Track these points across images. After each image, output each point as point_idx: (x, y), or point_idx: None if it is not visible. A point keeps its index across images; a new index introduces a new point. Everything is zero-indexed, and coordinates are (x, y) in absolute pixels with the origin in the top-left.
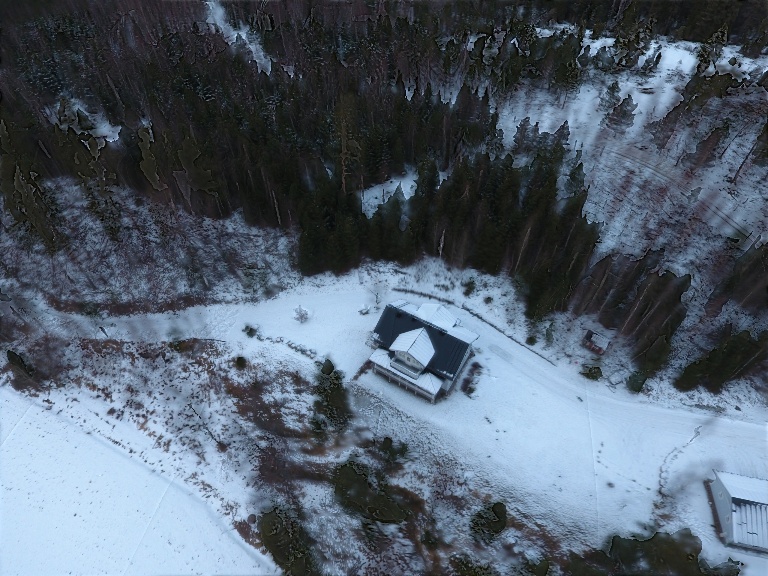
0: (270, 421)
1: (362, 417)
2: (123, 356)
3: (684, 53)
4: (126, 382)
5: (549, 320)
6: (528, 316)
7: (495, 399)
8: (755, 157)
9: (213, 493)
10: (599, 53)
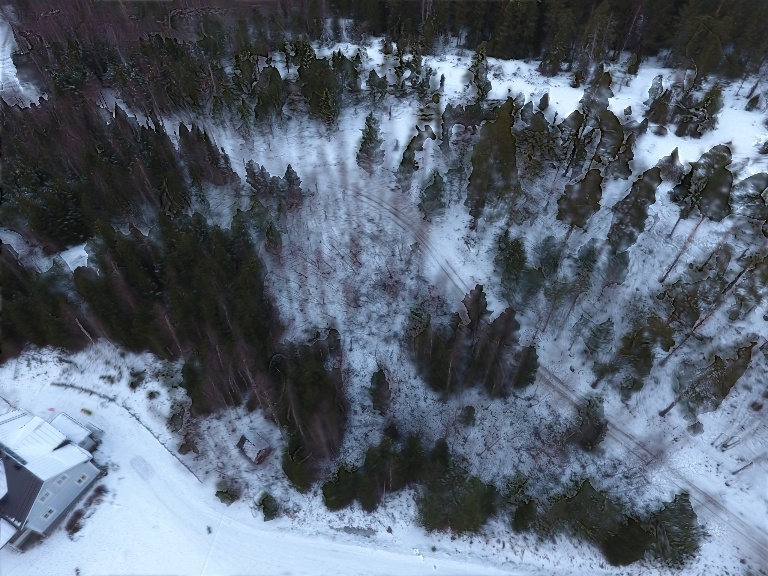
0: None
1: None
2: None
3: None
4: None
5: (216, 418)
6: (191, 415)
7: (102, 539)
8: None
9: None
10: (370, 77)
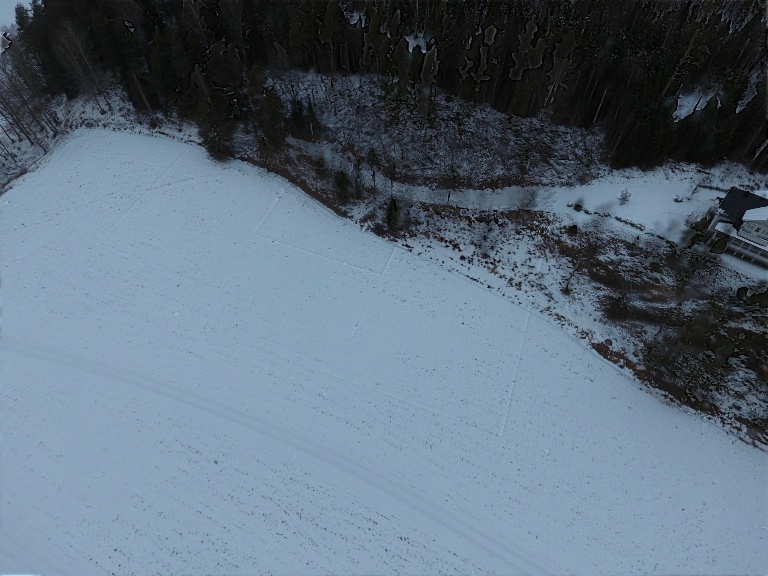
0: (608, 275)
1: (698, 277)
2: (460, 219)
3: None
4: (469, 238)
5: None
6: None
7: None
8: None
9: (567, 322)
10: None
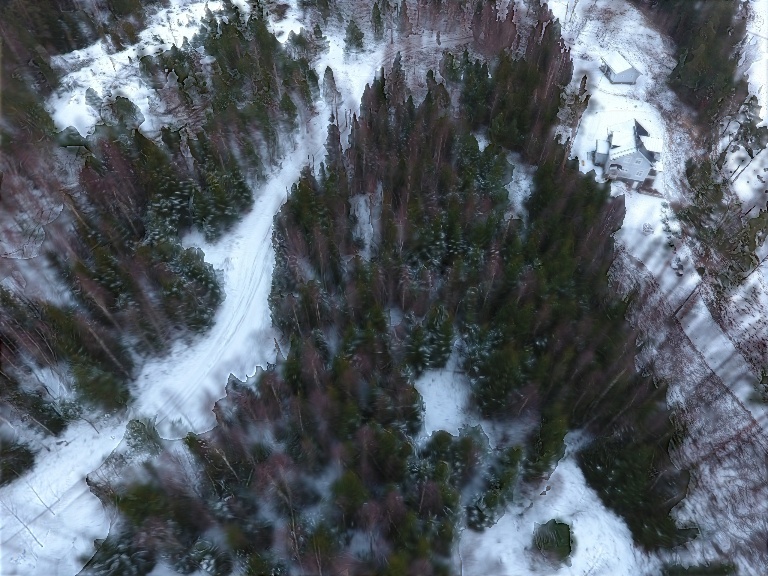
0: None
1: None
2: None
3: (202, 5)
4: None
5: None
6: None
7: None
8: (419, 2)
9: (761, 281)
10: None
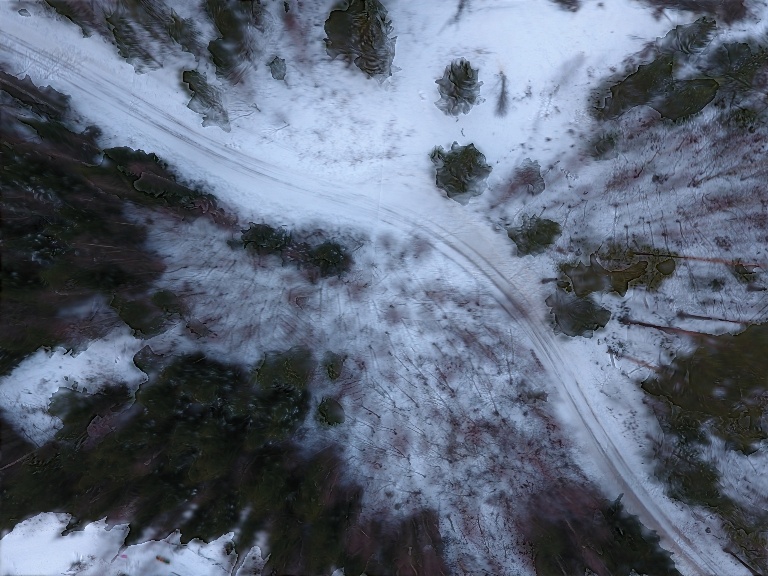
0: None
1: None
2: None
3: None
4: None
5: None
6: None
7: None
8: (652, 369)
9: None
10: None
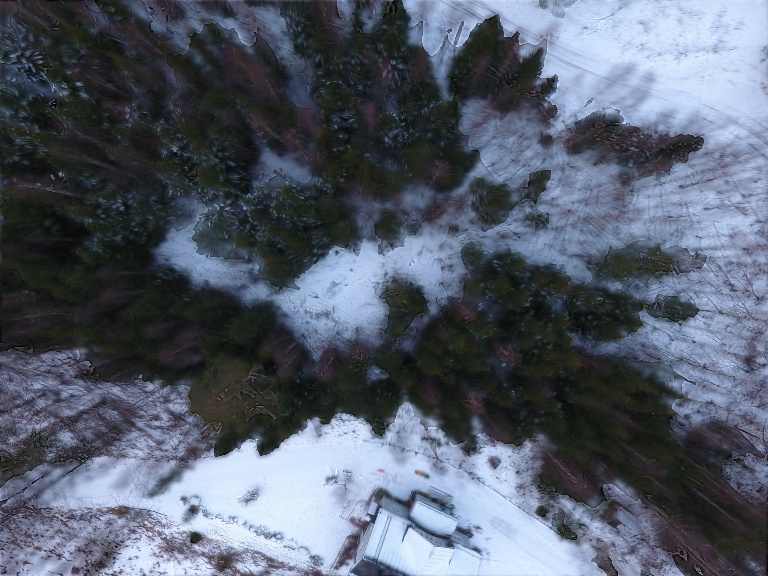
0: None
1: None
2: (48, 519)
3: None
4: (71, 544)
5: None
6: None
7: None
8: None
9: None
10: None
